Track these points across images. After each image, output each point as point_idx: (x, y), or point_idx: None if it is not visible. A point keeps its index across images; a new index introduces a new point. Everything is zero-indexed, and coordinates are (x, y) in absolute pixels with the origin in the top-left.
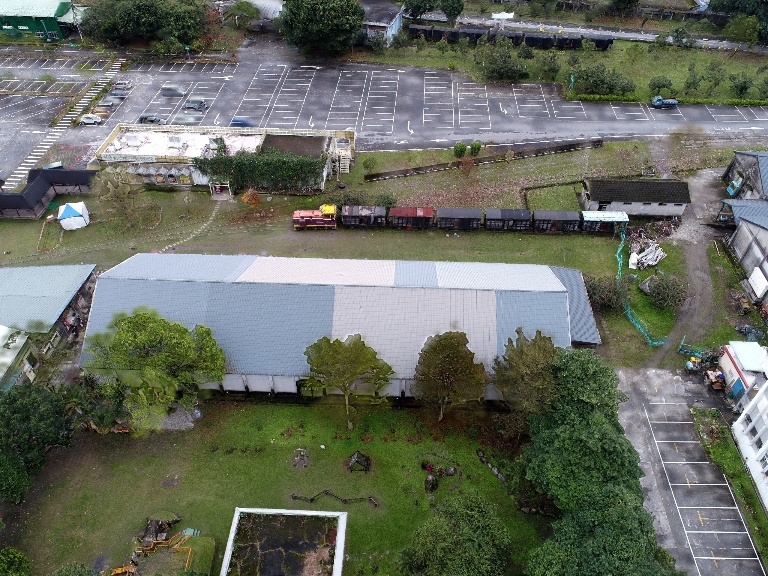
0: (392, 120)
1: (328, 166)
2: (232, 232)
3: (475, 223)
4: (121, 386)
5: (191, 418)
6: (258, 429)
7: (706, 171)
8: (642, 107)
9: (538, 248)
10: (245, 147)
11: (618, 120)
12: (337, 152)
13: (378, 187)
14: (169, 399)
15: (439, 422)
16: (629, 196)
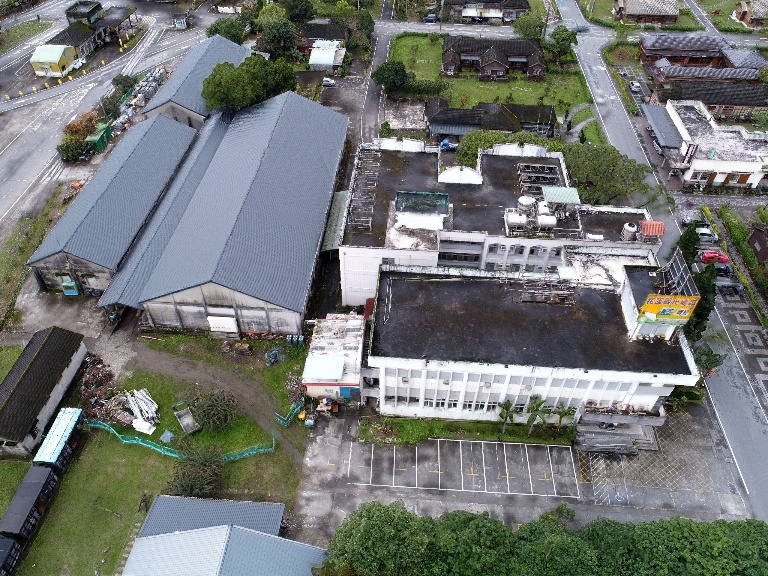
0: None
1: None
2: None
3: None
4: None
5: None
6: None
7: (22, 300)
8: None
9: (65, 542)
10: None
11: None
12: None
13: None
14: None
15: None
16: (40, 394)
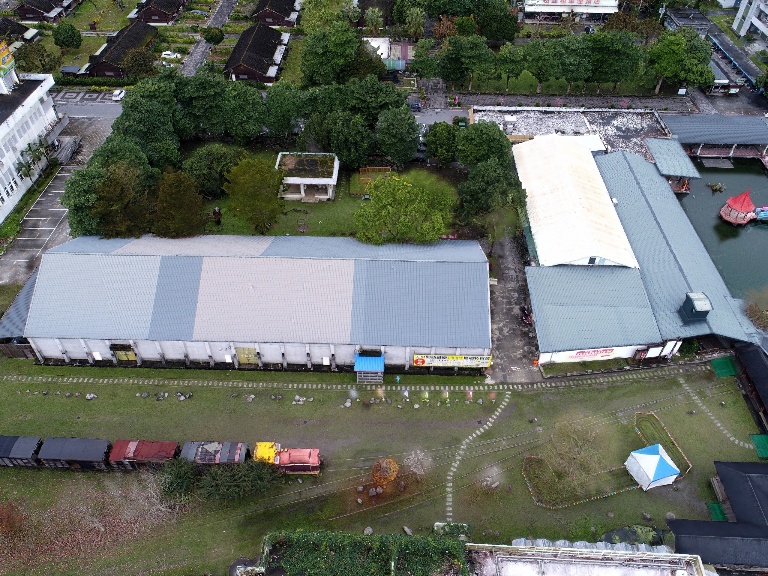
0: None
1: None
2: (410, 453)
3: None
4: None
5: None
6: None
7: None
8: None
9: None
10: None
11: None
12: None
13: (177, 569)
14: None
15: None
16: None
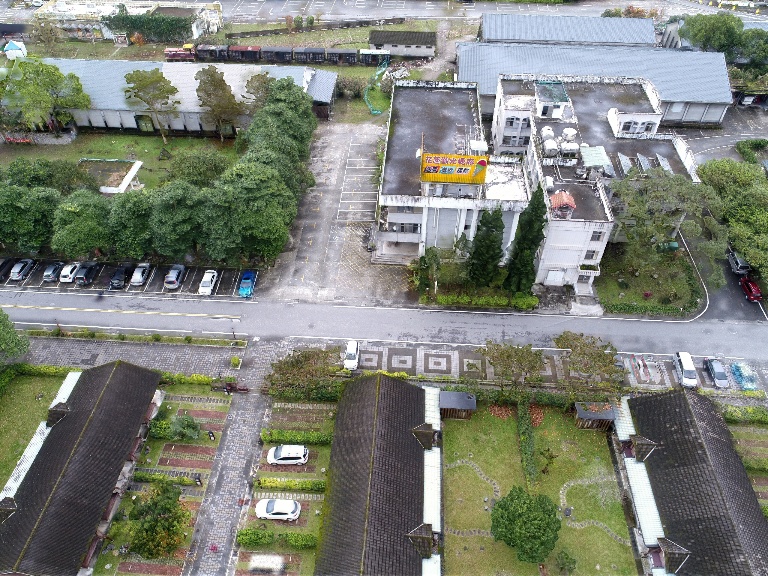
0: (260, 7)
1: (198, 26)
2: None
3: (287, 56)
4: (29, 123)
5: (70, 140)
6: (110, 145)
7: (469, 36)
8: (449, 2)
9: None
10: (141, 13)
11: (425, 9)
12: (204, 16)
13: None
14: (47, 106)
15: (222, 143)
16: (395, 40)
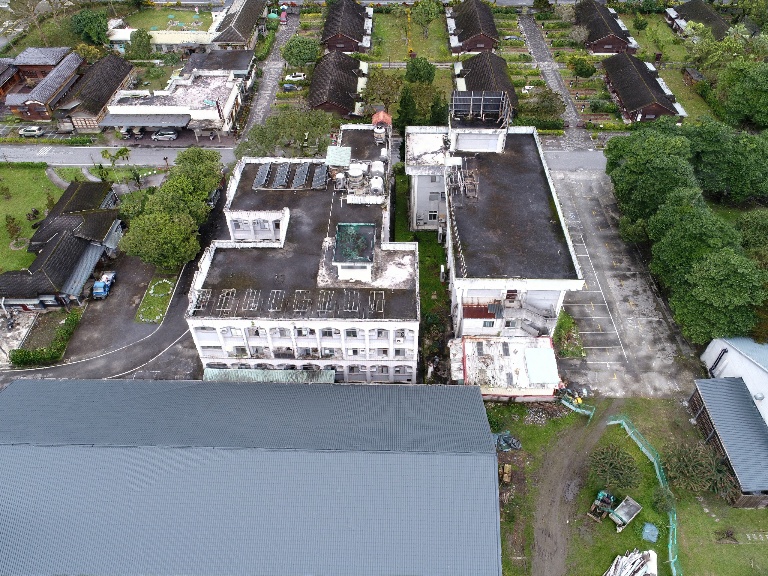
0: None
1: None
2: None
3: None
4: None
5: None
6: None
7: None
8: None
9: None
10: None
11: None
12: None
13: None
14: None
15: None
16: None
